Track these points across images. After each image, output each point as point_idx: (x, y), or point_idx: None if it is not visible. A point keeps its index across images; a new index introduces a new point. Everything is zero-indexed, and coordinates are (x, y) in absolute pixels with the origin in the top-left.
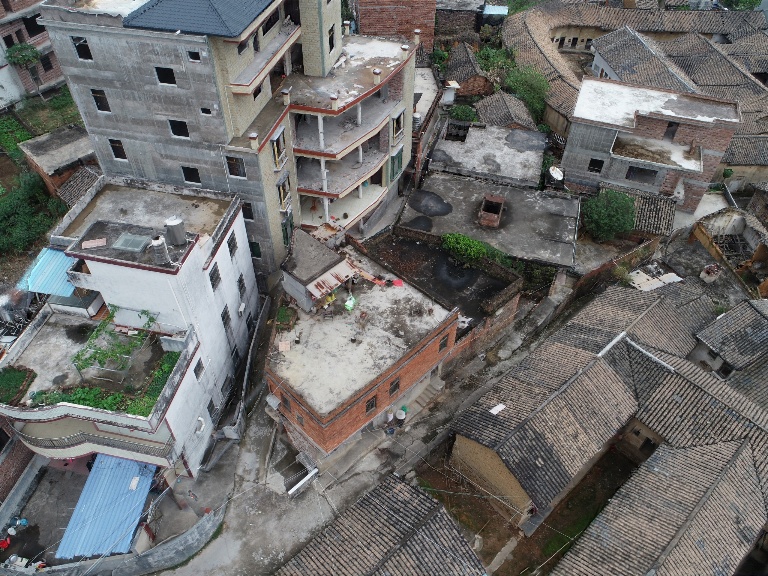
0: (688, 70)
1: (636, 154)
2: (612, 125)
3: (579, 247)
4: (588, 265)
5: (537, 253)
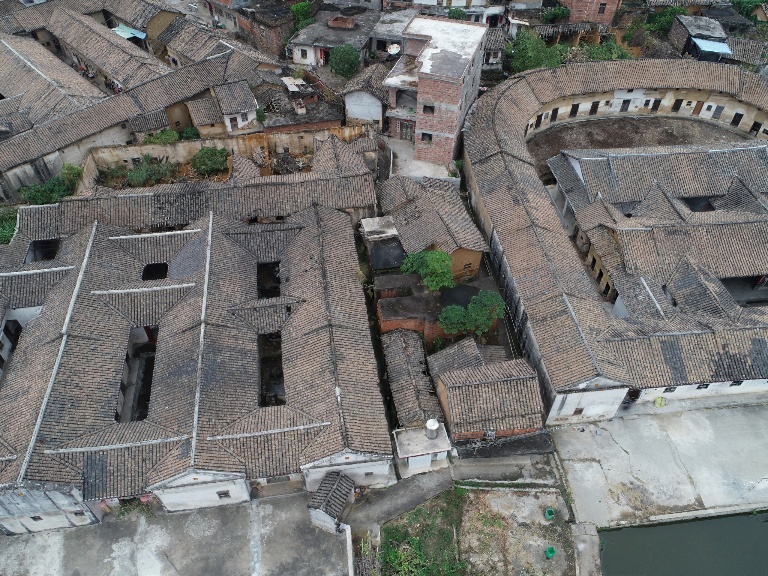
0: (730, 204)
1: (406, 63)
2: (406, 27)
3: (340, 78)
4: (321, 79)
5: (304, 35)
